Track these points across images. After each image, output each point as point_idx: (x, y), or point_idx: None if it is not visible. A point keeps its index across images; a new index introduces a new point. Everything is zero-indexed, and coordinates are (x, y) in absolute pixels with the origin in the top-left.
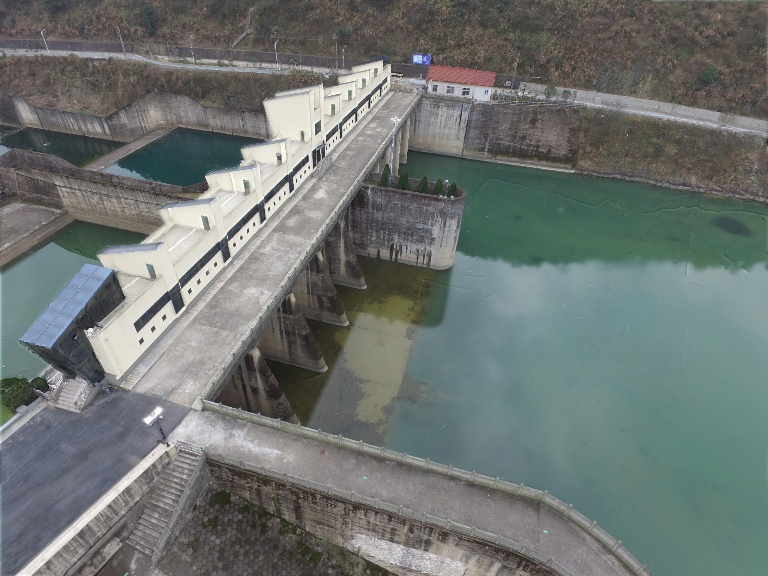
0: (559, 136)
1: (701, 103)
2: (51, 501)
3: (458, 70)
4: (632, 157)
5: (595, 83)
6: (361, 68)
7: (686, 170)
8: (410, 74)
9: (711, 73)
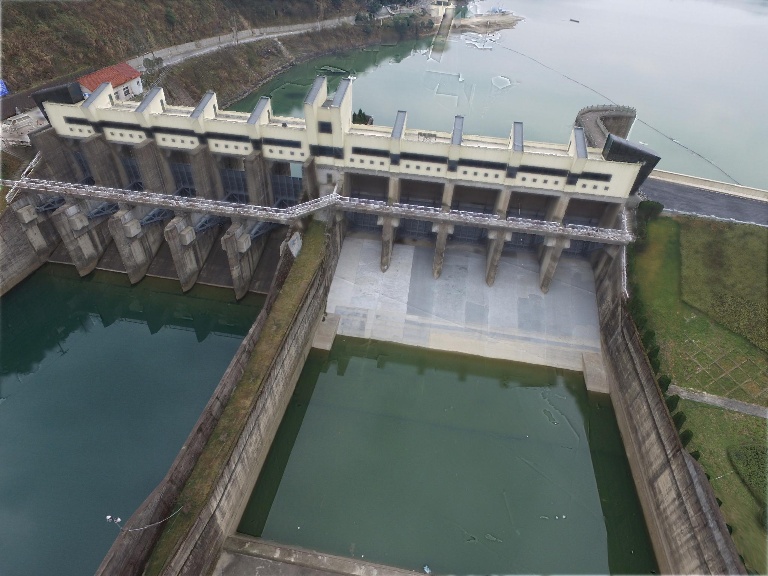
0: (187, 97)
1: (182, 39)
2: (675, 190)
3: (101, 73)
4: (217, 90)
5: (132, 49)
6: (97, 102)
7: (239, 83)
8: (0, 115)
9: (173, 15)
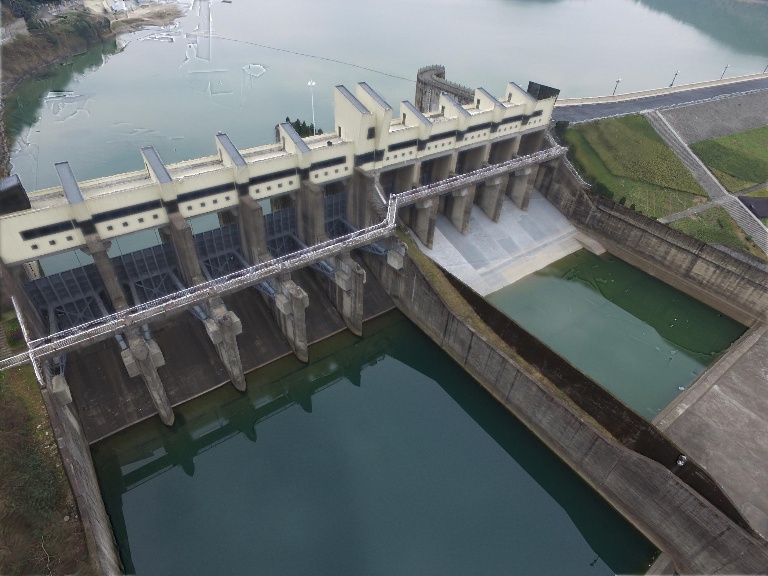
0: None
1: None
2: None
3: None
4: None
5: None
6: None
7: None
8: None
9: None
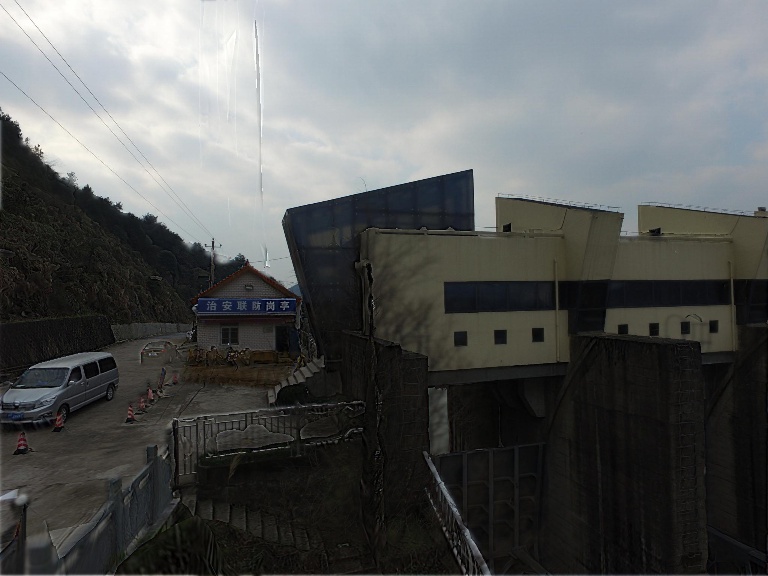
0: None
1: None
2: None
3: None
4: None
5: None
6: None
7: None
8: None
9: None
